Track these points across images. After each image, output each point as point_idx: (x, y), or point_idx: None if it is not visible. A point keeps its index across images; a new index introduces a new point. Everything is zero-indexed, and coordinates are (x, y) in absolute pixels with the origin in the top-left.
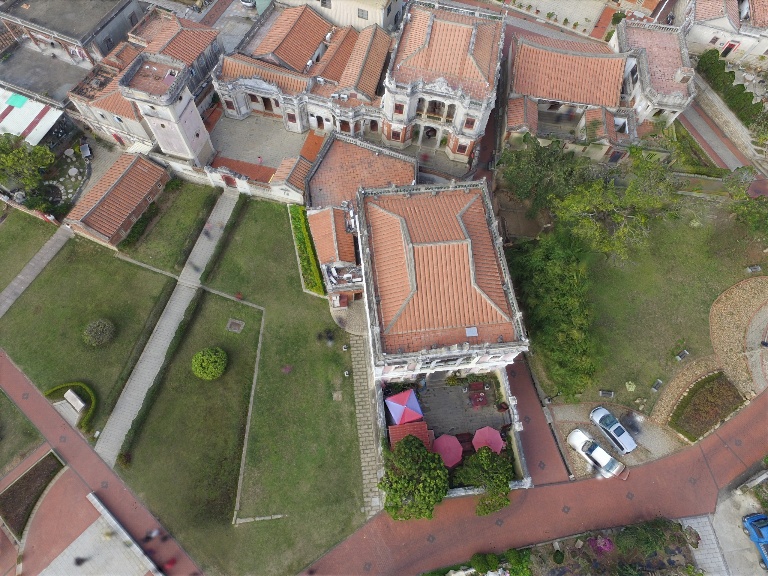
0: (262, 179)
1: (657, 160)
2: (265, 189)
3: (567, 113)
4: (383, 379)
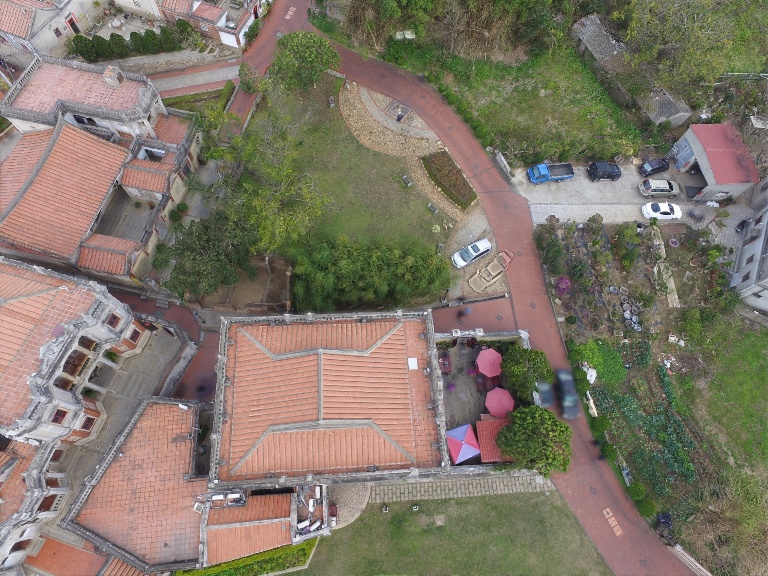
0: None
1: (236, 138)
2: None
3: (107, 203)
4: None
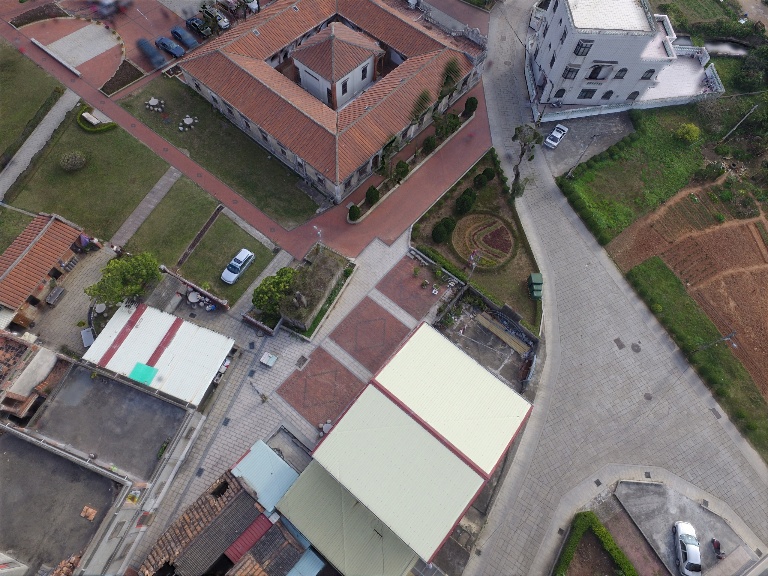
0: None
1: None
2: None
3: None
4: None
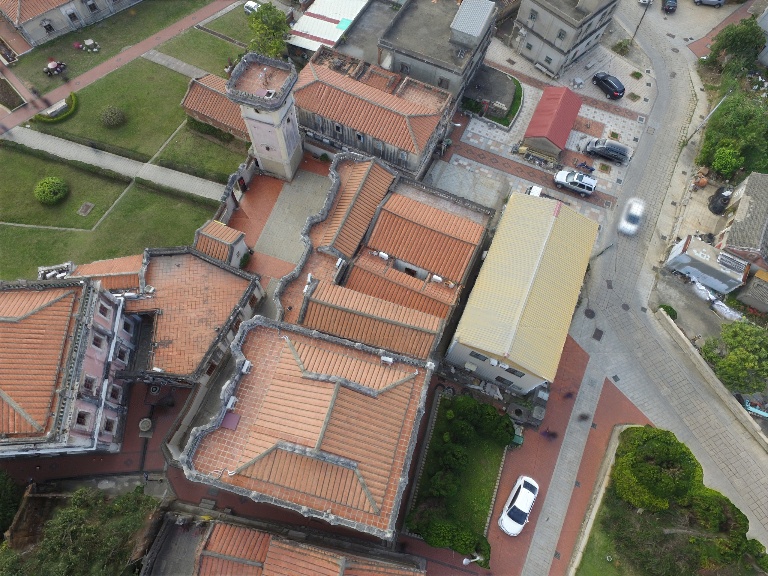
0: (247, 223)
1: None
2: None
3: None
4: None
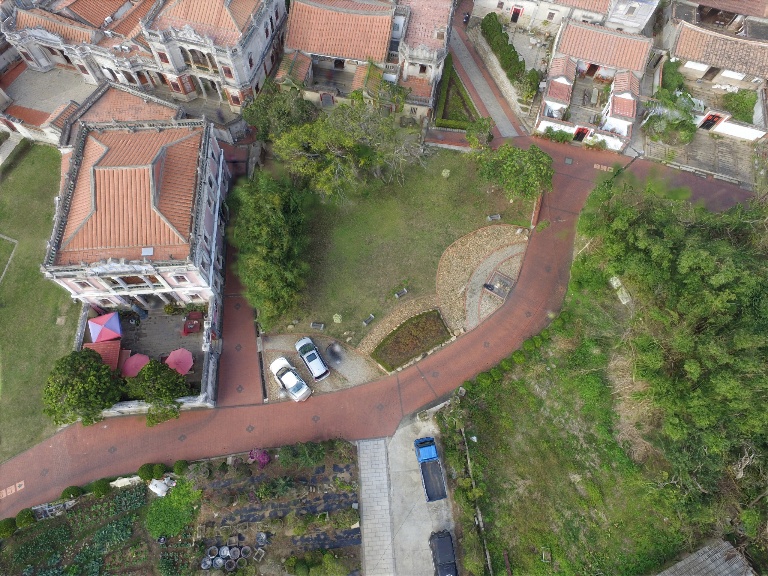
0: None
1: None
2: (41, 133)
3: (354, 72)
4: (93, 302)
